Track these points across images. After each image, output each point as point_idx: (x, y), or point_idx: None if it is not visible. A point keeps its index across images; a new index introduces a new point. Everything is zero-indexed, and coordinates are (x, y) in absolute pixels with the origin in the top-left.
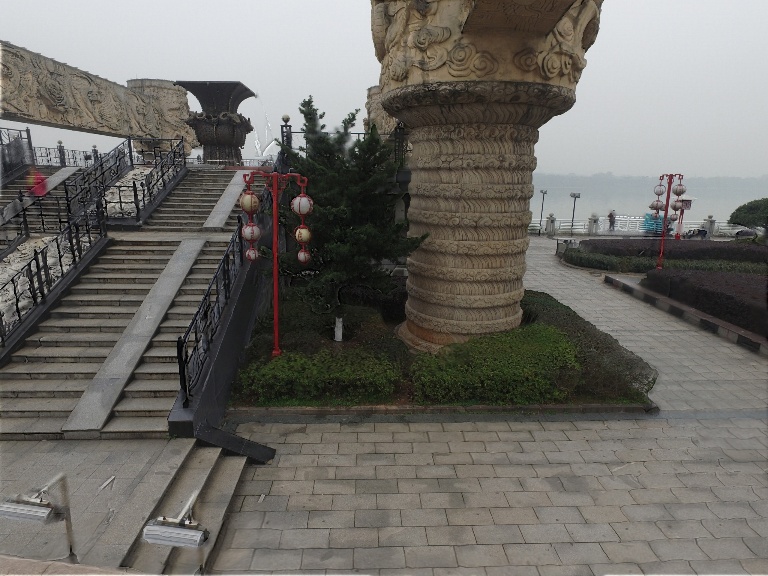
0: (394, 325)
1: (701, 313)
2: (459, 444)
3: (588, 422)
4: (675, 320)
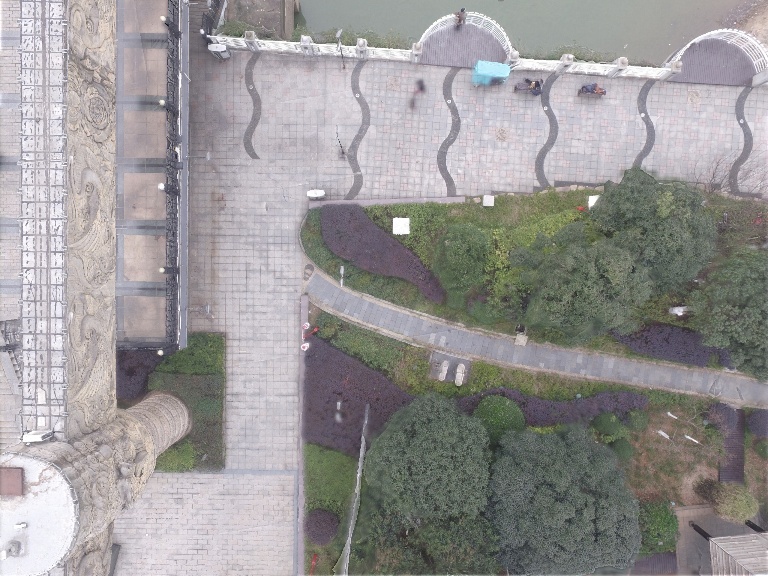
0: (140, 399)
1: None
2: (155, 485)
3: (198, 474)
4: (295, 379)
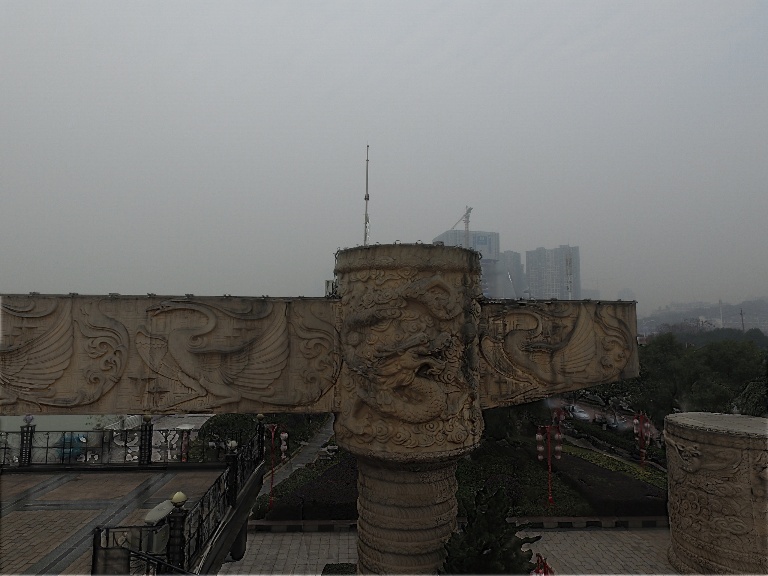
0: None
1: (341, 521)
2: None
3: None
4: (335, 534)
